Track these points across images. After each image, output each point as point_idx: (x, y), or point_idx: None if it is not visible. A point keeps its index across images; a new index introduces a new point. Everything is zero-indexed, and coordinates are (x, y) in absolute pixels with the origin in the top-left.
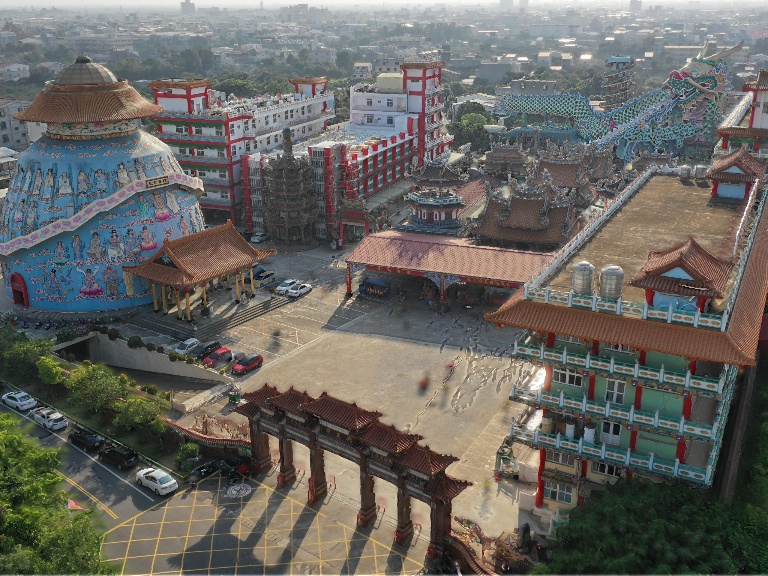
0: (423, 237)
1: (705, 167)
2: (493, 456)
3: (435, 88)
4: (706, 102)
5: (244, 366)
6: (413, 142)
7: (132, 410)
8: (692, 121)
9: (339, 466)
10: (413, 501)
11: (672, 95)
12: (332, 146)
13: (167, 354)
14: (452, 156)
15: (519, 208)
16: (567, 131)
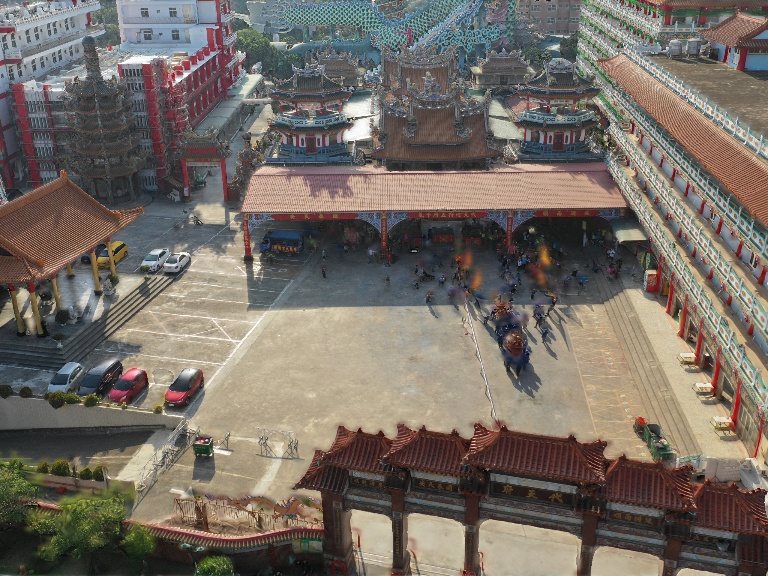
0: (319, 169)
1: (700, 40)
2: (642, 454)
3: None
4: (507, 1)
5: (184, 392)
6: (214, 60)
7: (87, 528)
8: (496, 22)
9: (454, 527)
10: (609, 558)
11: None
12: (151, 61)
13: (40, 397)
14: (250, 77)
15: (426, 120)
16: (360, 43)
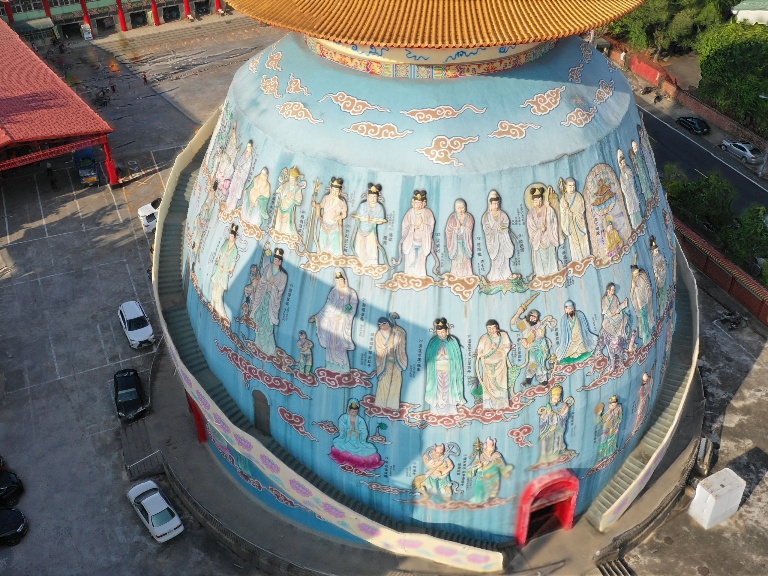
0: None
1: None
2: None
3: None
4: None
5: None
6: None
7: None
8: None
9: None
10: None
11: None
12: None
13: None
14: None
15: None
16: None
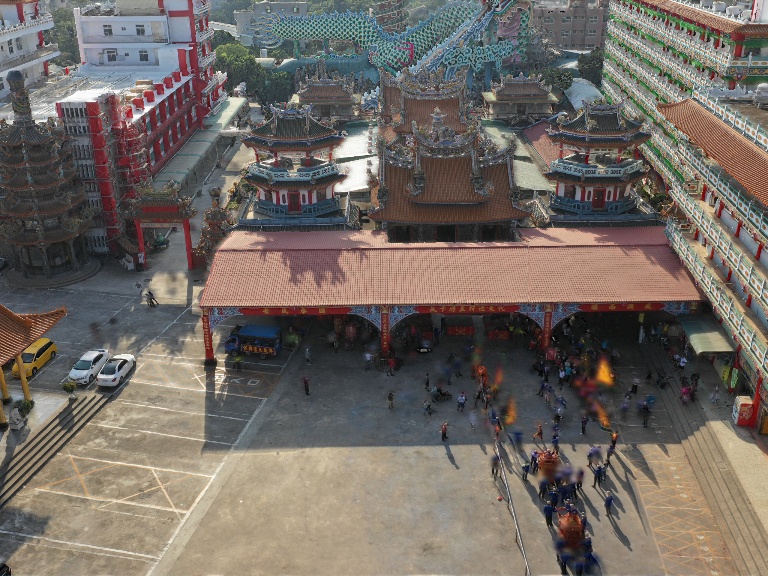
0: (303, 238)
1: None
2: None
3: (203, 5)
4: (520, 14)
5: None
6: (187, 85)
7: None
8: (507, 38)
9: None
10: None
11: (485, 6)
12: (98, 98)
13: None
14: (231, 102)
15: (435, 172)
16: (356, 59)
